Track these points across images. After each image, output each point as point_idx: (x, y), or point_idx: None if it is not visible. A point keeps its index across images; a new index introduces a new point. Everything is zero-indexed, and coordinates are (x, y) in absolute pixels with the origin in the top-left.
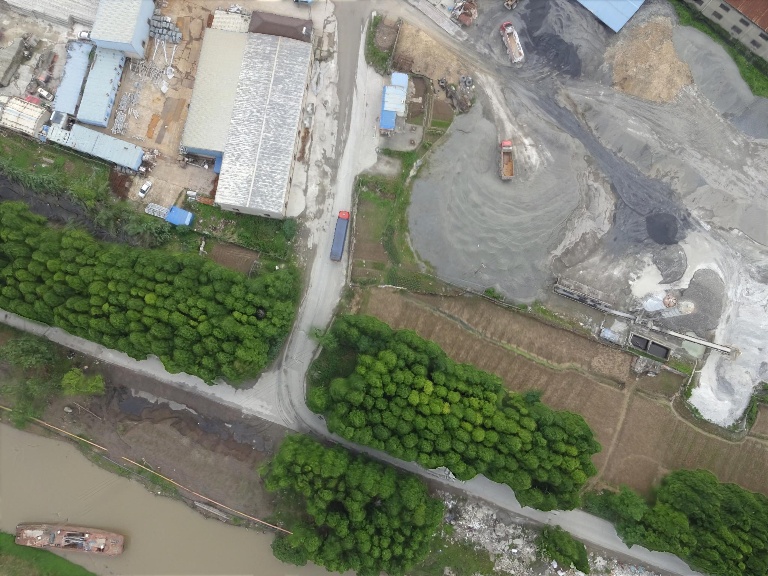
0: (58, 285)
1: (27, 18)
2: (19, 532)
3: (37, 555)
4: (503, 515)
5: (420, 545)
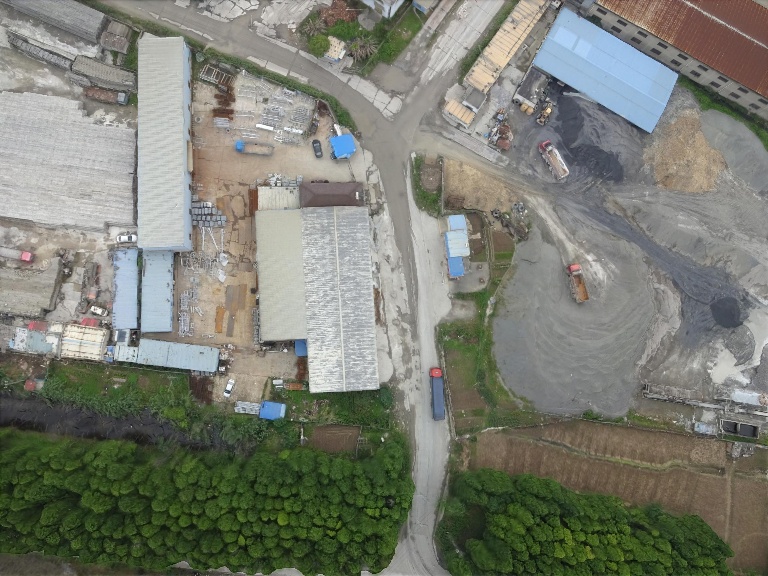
0: (189, 533)
1: (56, 231)
2: None
3: None
4: None
5: None
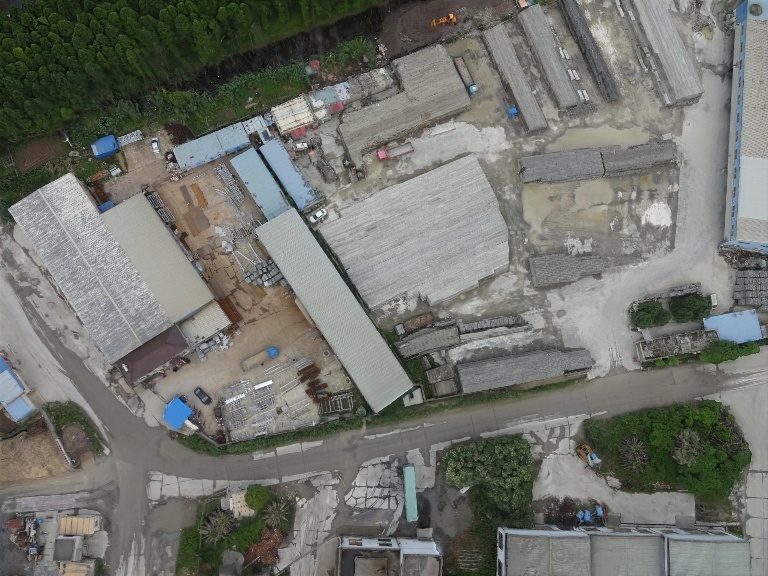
0: (88, 4)
1: (378, 189)
2: None
3: None
4: None
5: None
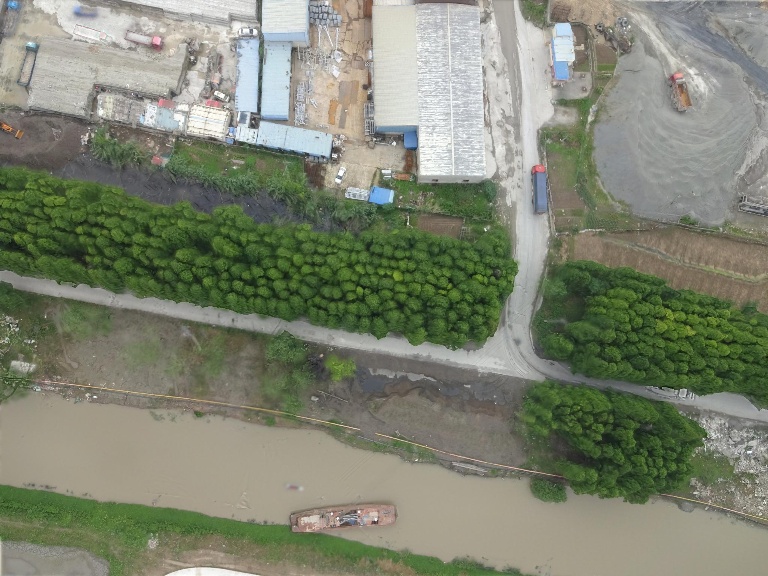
0: (312, 277)
1: (183, 23)
2: (294, 521)
3: (315, 539)
4: (734, 422)
5: None
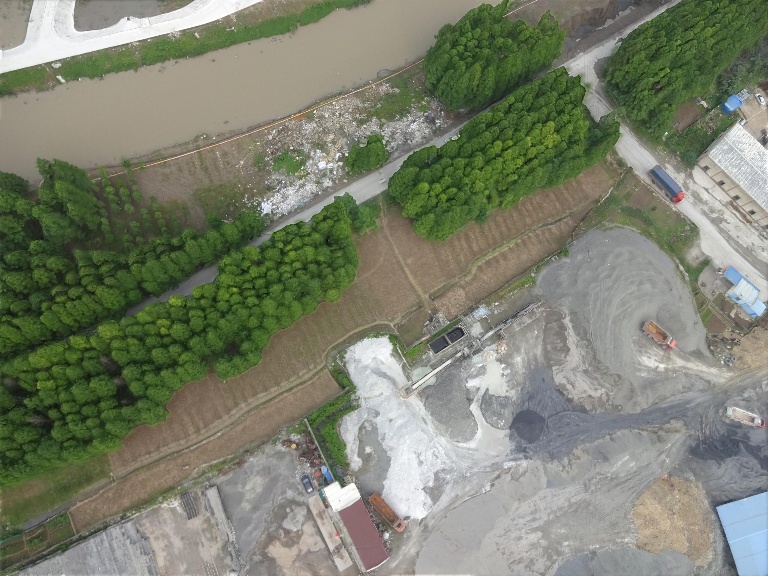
0: None
1: None
2: None
3: None
4: (406, 148)
5: (447, 68)
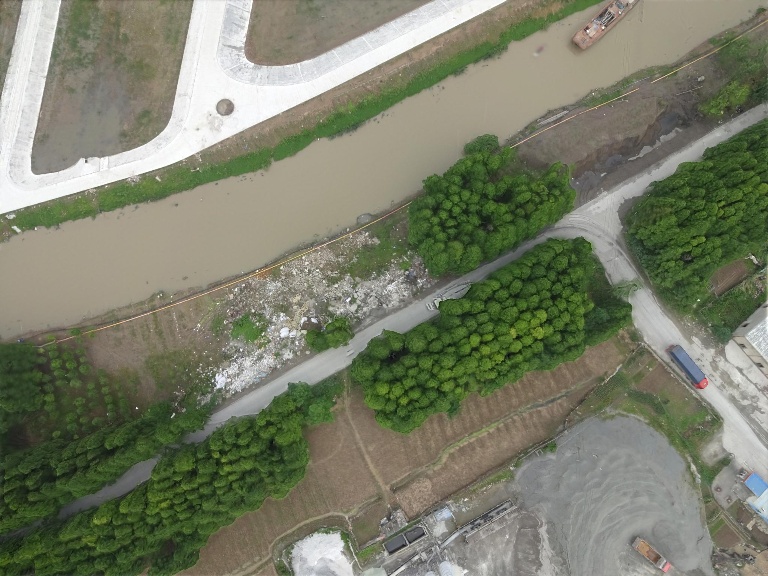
0: None
1: None
2: None
3: None
4: (380, 313)
5: (428, 234)
